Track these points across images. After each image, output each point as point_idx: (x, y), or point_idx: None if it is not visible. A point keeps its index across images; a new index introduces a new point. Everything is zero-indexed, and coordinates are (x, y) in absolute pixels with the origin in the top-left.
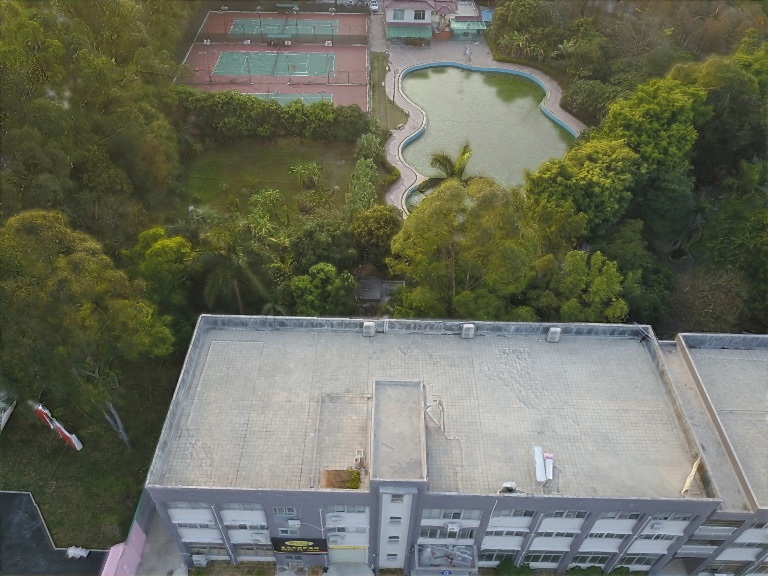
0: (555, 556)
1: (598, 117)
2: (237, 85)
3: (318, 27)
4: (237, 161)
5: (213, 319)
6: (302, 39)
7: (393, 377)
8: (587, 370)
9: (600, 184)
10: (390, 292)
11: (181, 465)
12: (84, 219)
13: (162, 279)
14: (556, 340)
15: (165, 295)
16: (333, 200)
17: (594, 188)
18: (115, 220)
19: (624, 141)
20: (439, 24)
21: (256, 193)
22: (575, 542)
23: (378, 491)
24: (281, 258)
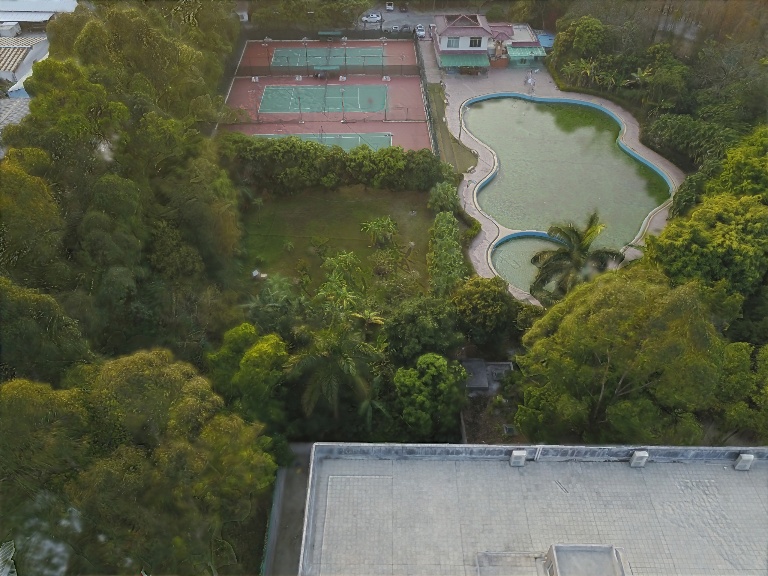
0: None
1: (691, 156)
2: (287, 124)
3: (368, 58)
4: (298, 214)
5: (328, 448)
6: (350, 70)
7: (559, 525)
8: None
9: (741, 252)
10: (498, 378)
11: None
12: (161, 316)
13: (258, 391)
14: (746, 468)
15: (260, 408)
16: (411, 259)
17: (734, 256)
18: (195, 315)
19: (758, 198)
20: (495, 51)
21: (324, 252)
22: None
23: None
24: (367, 336)
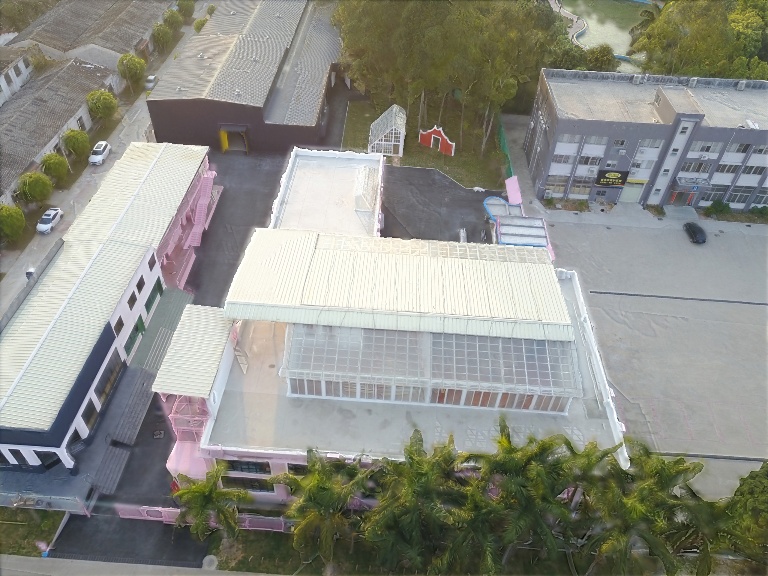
0: (745, 196)
1: None
2: None
3: None
4: None
5: (548, 72)
6: None
7: None
8: (763, 100)
9: (745, 33)
10: None
11: None
12: None
13: None
14: (742, 89)
15: None
16: None
17: (741, 35)
18: None
19: (756, 12)
20: None
21: None
22: (762, 179)
23: (680, 120)
24: None
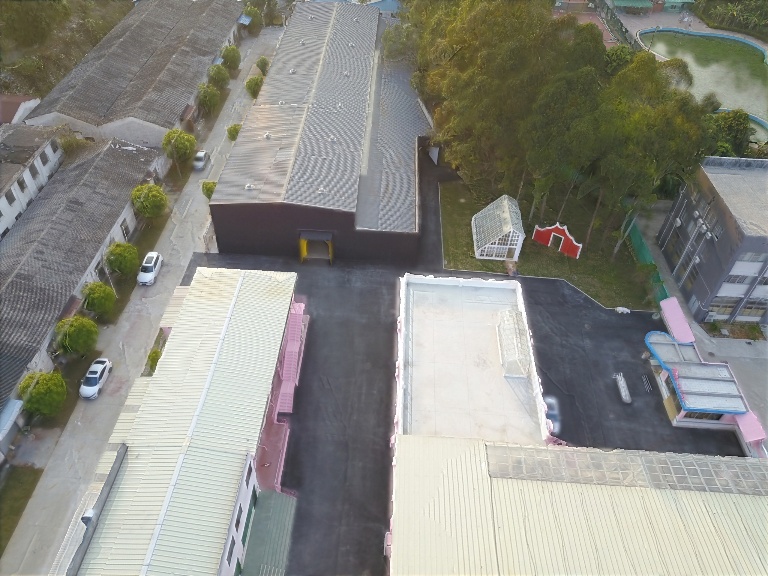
0: None
1: None
2: None
3: None
4: None
5: None
6: None
7: None
8: None
9: None
10: None
11: (746, 232)
12: None
13: None
14: None
15: None
16: None
17: None
18: None
19: None
20: None
21: None
22: None
23: None
24: None
